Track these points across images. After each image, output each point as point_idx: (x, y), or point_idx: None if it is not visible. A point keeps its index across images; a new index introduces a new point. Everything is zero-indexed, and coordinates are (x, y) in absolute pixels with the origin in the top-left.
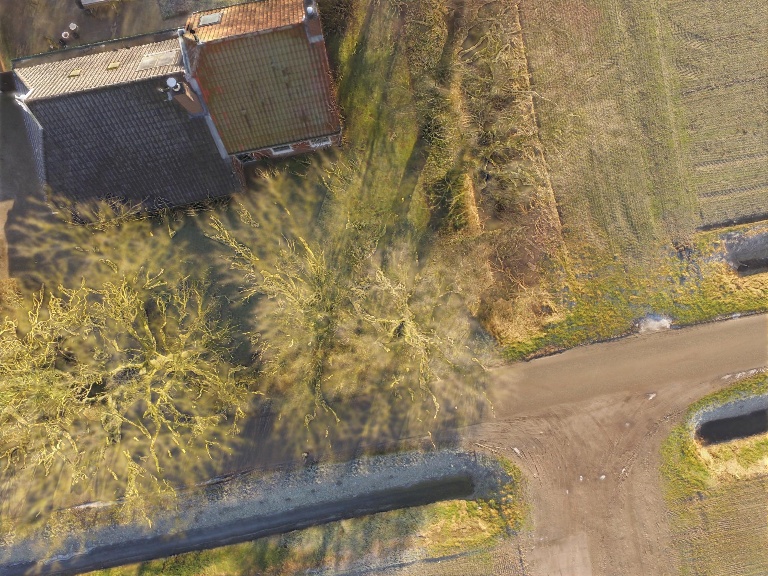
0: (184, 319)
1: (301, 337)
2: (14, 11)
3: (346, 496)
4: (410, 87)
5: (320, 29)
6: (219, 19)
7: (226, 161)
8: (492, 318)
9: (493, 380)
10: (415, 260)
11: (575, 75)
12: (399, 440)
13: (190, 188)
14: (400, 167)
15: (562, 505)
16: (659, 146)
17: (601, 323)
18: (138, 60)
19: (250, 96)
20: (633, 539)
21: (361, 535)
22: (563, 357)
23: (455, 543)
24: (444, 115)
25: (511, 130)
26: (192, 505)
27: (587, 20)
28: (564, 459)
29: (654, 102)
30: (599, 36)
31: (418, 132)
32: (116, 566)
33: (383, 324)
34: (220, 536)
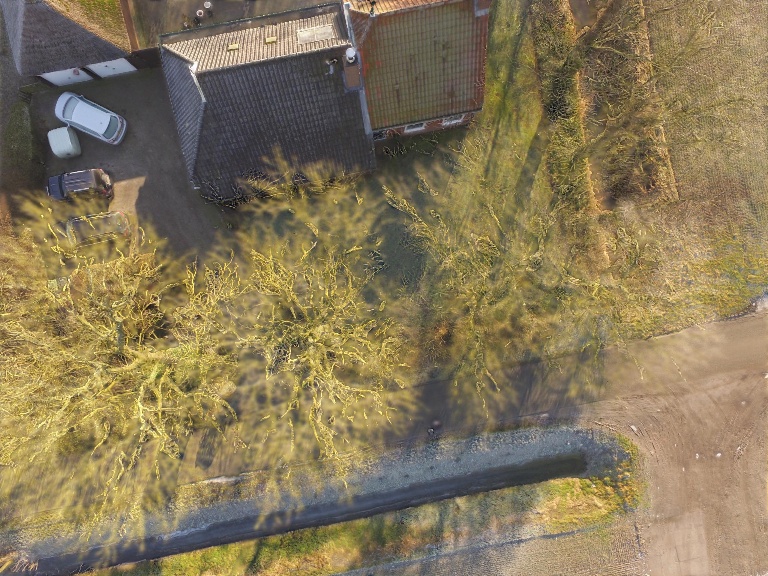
0: (310, 296)
1: (424, 314)
2: None
3: (461, 473)
4: (535, 67)
5: (490, 2)
6: None
7: (369, 137)
8: None
9: (612, 358)
10: None
11: (697, 56)
12: (518, 417)
13: (328, 164)
14: (524, 146)
15: (678, 482)
16: None
17: (719, 302)
18: (294, 35)
19: (406, 70)
20: (748, 517)
21: (477, 512)
22: (681, 336)
23: (572, 520)
24: (568, 95)
25: None
26: (314, 481)
27: None
28: (681, 437)
29: None
30: (722, 17)
31: (543, 111)
32: (233, 542)
33: (585, 287)
34: (336, 513)
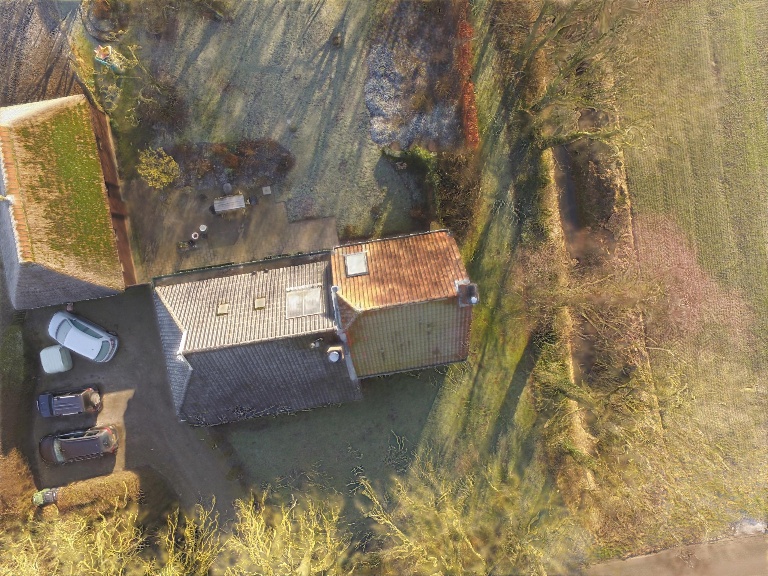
0: None
1: (404, 529)
2: (146, 210)
3: None
4: (524, 293)
5: None
6: (367, 268)
7: (354, 381)
8: (591, 516)
9: None
10: (520, 459)
11: None
12: None
13: (314, 399)
14: (510, 370)
15: None
16: (764, 358)
17: (698, 526)
18: (283, 297)
19: (392, 341)
20: None
21: None
22: (659, 557)
23: None
24: (555, 321)
25: (618, 335)
26: None
27: (699, 235)
28: None
29: (761, 316)
30: (710, 251)
31: (529, 337)
32: None
33: None
34: None
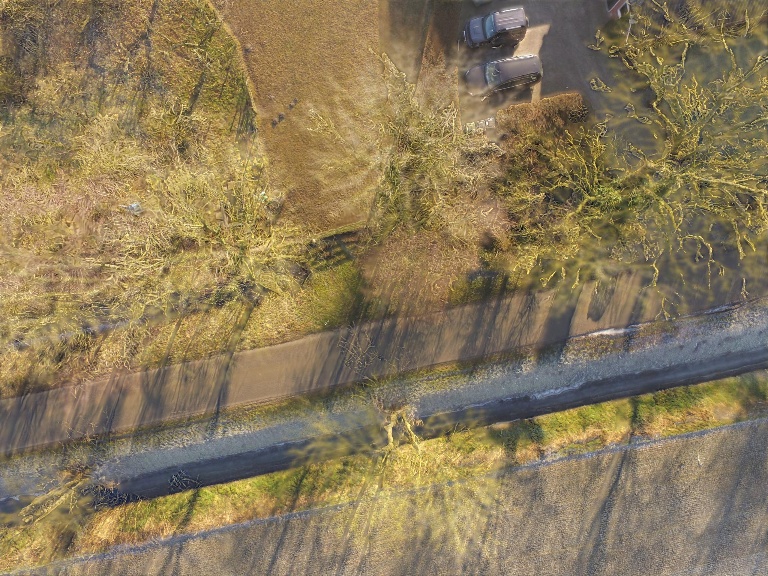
0: None
1: None
2: None
3: None
4: None
5: None
6: None
7: None
8: None
9: None
10: None
11: None
12: None
13: (757, 1)
14: None
15: None
16: None
17: None
18: None
19: None
20: None
21: None
22: None
23: None
24: None
25: None
26: (700, 333)
27: None
28: None
29: None
30: None
31: None
32: (605, 401)
33: None
34: (704, 372)
